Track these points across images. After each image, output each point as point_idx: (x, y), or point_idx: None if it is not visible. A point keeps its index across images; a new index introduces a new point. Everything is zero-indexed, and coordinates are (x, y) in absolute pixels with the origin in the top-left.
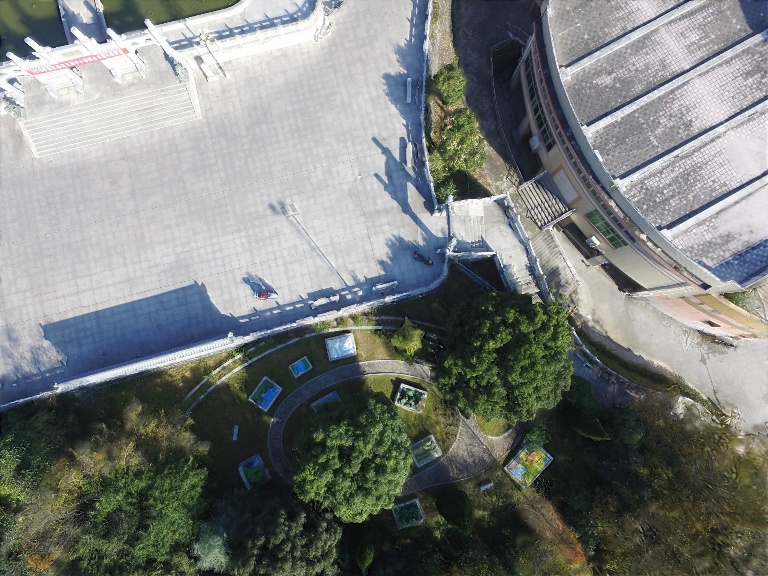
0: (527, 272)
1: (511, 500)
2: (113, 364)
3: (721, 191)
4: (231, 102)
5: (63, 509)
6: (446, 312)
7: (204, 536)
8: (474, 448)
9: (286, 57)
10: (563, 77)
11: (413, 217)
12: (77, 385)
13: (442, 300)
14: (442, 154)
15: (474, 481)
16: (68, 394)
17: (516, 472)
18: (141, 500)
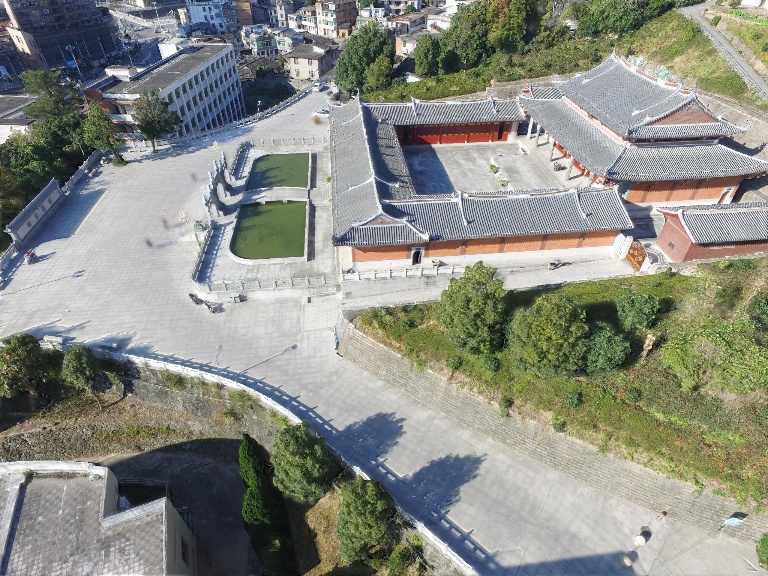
0: None
1: None
2: (62, 206)
3: None
4: (178, 254)
5: None
6: None
7: None
8: None
9: None
10: (13, 479)
11: (5, 338)
12: None
13: None
14: None
15: None
16: None
17: None
18: None
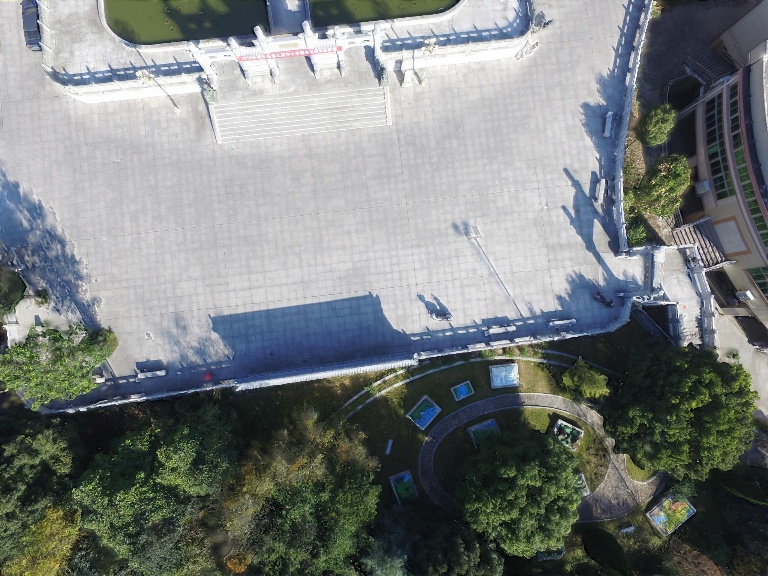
0: (695, 324)
1: (647, 545)
2: (280, 365)
3: None
4: (423, 111)
5: (258, 515)
6: (610, 353)
7: (379, 554)
8: (620, 491)
9: (484, 71)
10: None
11: (596, 255)
12: (257, 386)
13: (607, 341)
14: (637, 196)
15: (616, 523)
16: (227, 388)
17: (658, 519)
18: (317, 510)
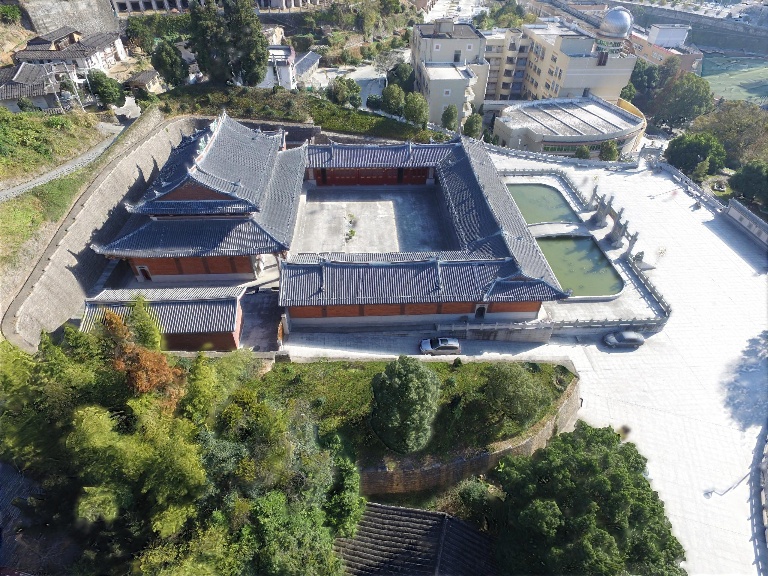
0: None
1: None
2: (764, 252)
3: (605, 122)
4: None
5: None
6: None
7: None
8: None
9: None
10: None
11: None
12: None
13: None
14: (612, 160)
15: None
16: None
17: None
18: None
